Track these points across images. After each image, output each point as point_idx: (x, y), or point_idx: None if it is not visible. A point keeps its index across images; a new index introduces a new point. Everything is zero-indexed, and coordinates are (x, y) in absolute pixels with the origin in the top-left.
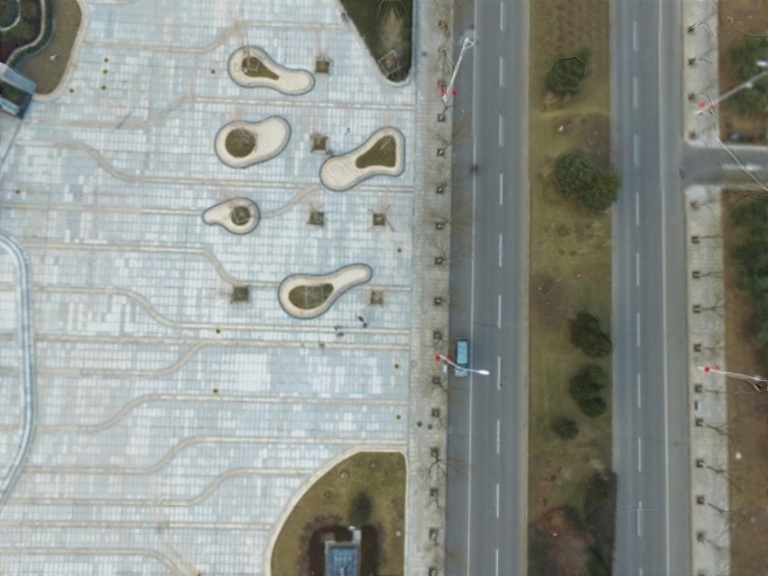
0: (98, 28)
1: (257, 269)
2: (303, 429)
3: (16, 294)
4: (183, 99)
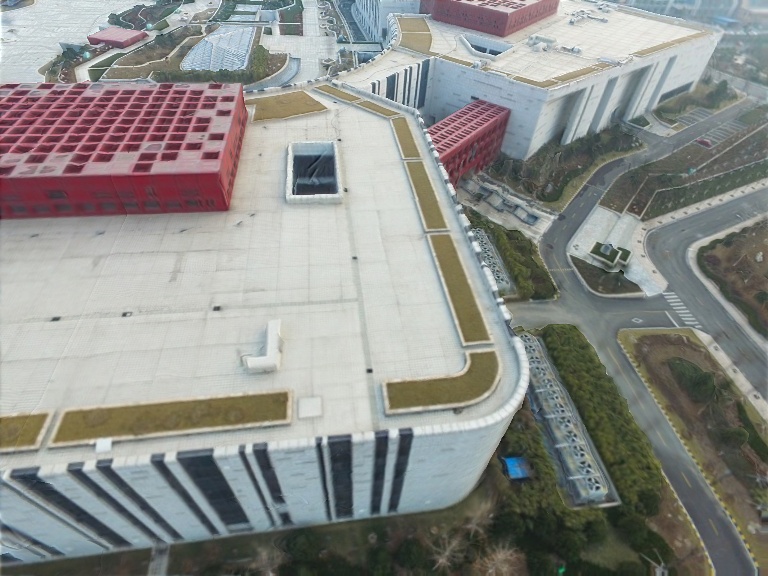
0: (33, 68)
1: (2, 34)
2: (4, 14)
3: (92, 31)
4: (6, 57)
